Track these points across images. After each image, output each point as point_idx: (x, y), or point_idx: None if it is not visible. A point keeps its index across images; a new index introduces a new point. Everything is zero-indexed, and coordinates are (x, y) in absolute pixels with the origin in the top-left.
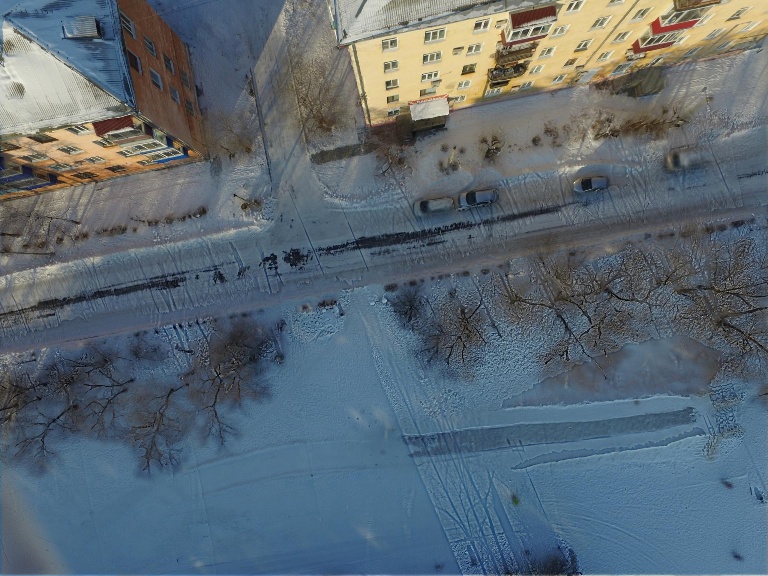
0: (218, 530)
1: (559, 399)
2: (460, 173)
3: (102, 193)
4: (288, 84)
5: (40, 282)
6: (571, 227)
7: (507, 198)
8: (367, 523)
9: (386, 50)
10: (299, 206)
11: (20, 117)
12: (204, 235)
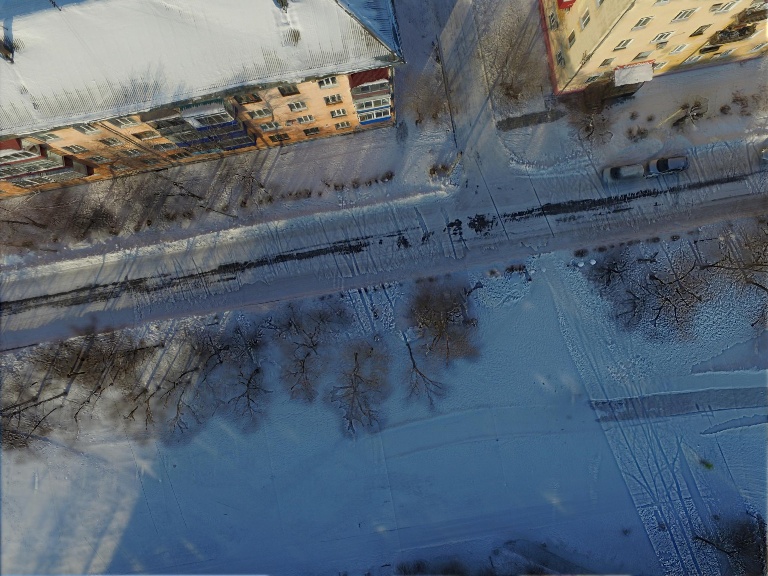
0: (400, 495)
1: (751, 364)
2: (648, 141)
3: (286, 157)
4: (474, 51)
5: (221, 246)
6: (757, 195)
7: (694, 166)
8: (552, 488)
9: (657, 3)
10: (484, 172)
11: (290, 65)
12: (391, 200)
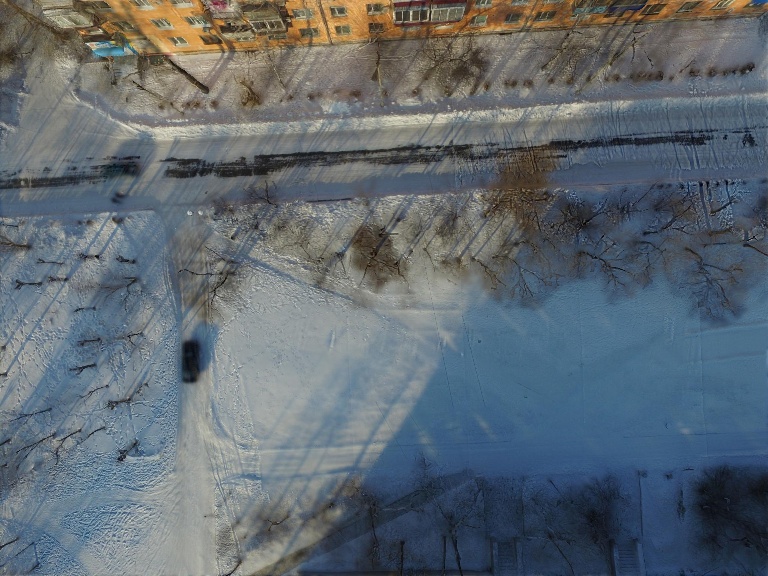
0: (712, 400)
1: None
2: None
3: None
4: None
5: (556, 121)
6: None
7: None
8: None
9: None
10: None
11: None
12: (747, 93)
